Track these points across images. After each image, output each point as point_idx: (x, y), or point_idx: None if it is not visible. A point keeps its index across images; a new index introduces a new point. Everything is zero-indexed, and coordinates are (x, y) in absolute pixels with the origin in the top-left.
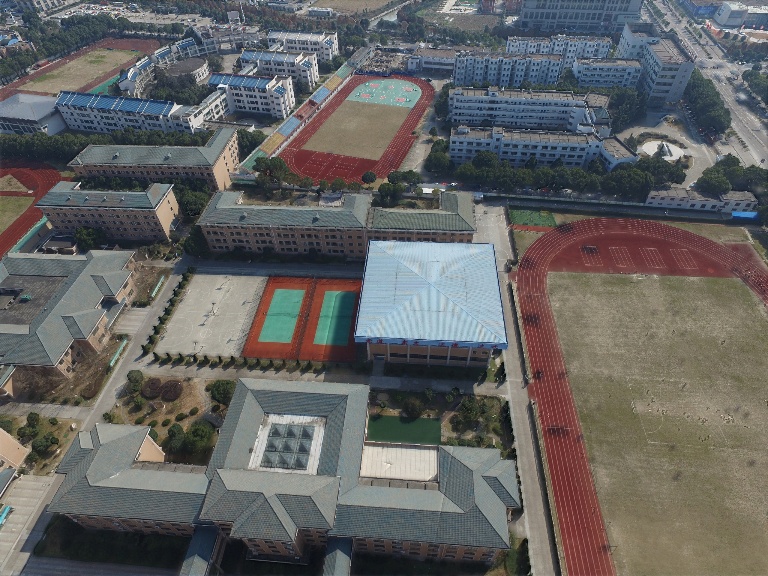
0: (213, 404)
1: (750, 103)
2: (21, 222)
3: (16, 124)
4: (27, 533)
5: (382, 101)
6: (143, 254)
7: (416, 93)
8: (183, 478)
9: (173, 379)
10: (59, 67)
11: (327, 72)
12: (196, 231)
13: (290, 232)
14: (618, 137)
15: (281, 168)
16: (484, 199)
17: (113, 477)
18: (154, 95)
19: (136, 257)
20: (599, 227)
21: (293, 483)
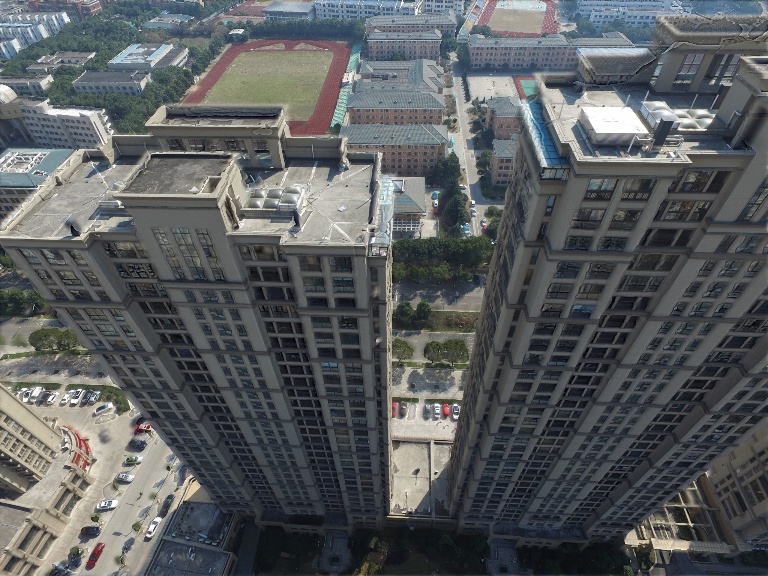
0: None
1: None
2: (337, 61)
3: (287, 17)
4: (466, 145)
5: (522, 8)
6: None
7: (543, 4)
8: None
9: None
10: None
11: None
12: (466, 53)
13: (523, 51)
14: None
15: None
16: None
17: None
18: None
19: None
20: None
21: None
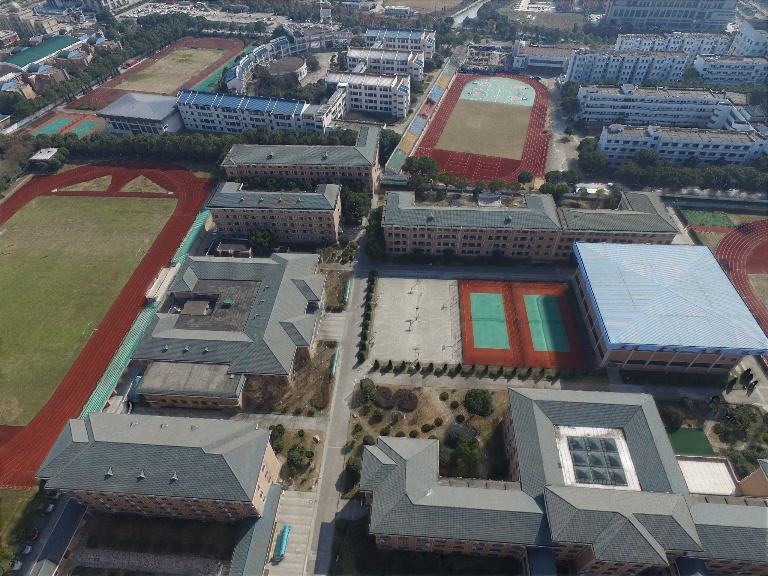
0: (455, 414)
1: None
2: (174, 224)
3: (135, 124)
4: (314, 553)
5: (498, 100)
6: None
7: (530, 91)
8: (504, 496)
9: (402, 388)
10: (149, 66)
11: (429, 70)
12: (377, 233)
13: (478, 234)
14: None
15: (433, 168)
16: None
17: (429, 495)
18: (262, 94)
19: None
20: None
21: (640, 501)
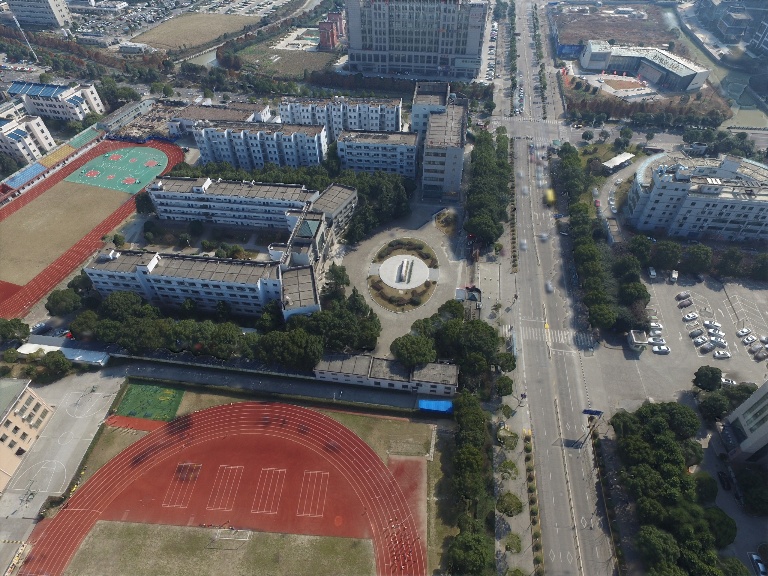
0: None
1: (557, 190)
2: None
3: None
4: None
5: (104, 183)
6: None
7: (157, 170)
8: None
9: None
10: None
11: None
12: None
13: None
14: (360, 247)
15: None
16: (107, 363)
17: None
18: None
19: None
20: (232, 422)
21: None
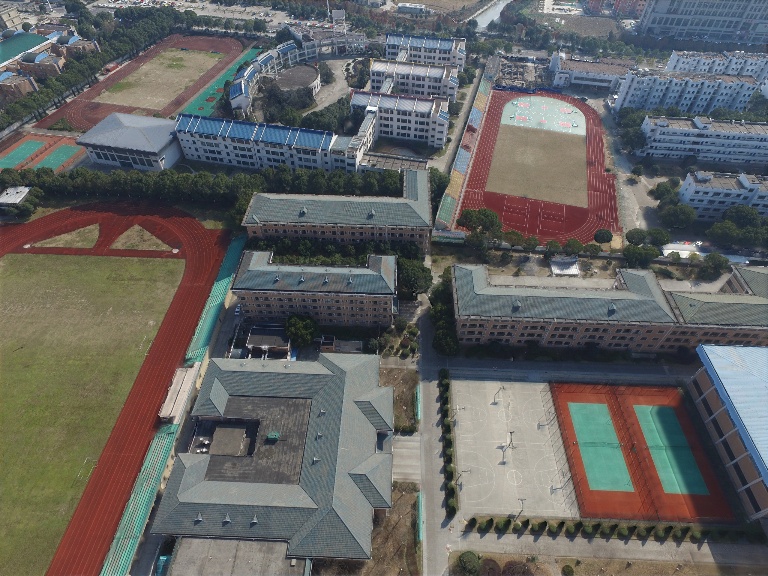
0: None
1: None
2: (184, 298)
3: (124, 154)
4: None
5: (546, 126)
6: (373, 350)
7: (578, 116)
8: None
9: (511, 559)
10: (133, 72)
11: (460, 86)
12: (448, 323)
13: (574, 326)
14: None
15: (495, 224)
16: None
17: None
18: (273, 114)
19: (361, 353)
20: None
21: None
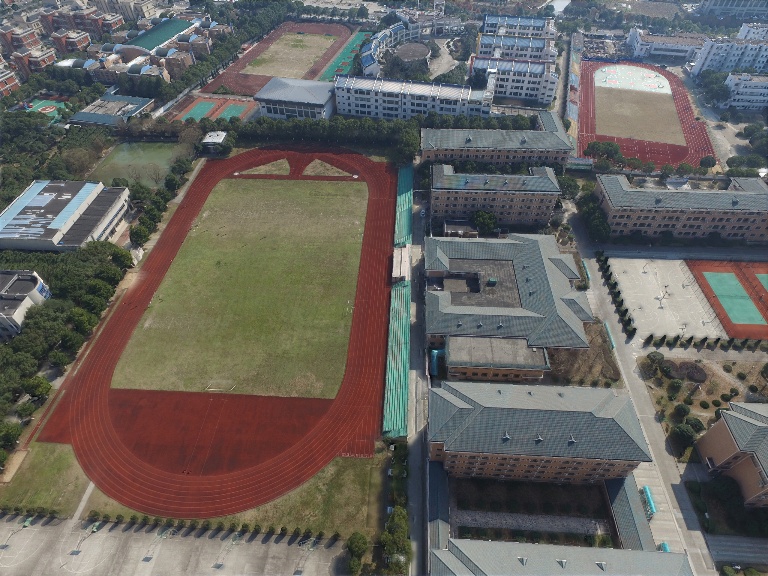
0: (746, 385)
1: None
2: (376, 207)
3: (293, 108)
4: (678, 512)
5: (635, 87)
6: None
7: (662, 79)
8: None
9: (683, 361)
10: (264, 51)
11: None
12: (603, 215)
13: (704, 215)
14: None
15: (617, 153)
16: None
17: None
18: None
19: None
20: None
21: None
